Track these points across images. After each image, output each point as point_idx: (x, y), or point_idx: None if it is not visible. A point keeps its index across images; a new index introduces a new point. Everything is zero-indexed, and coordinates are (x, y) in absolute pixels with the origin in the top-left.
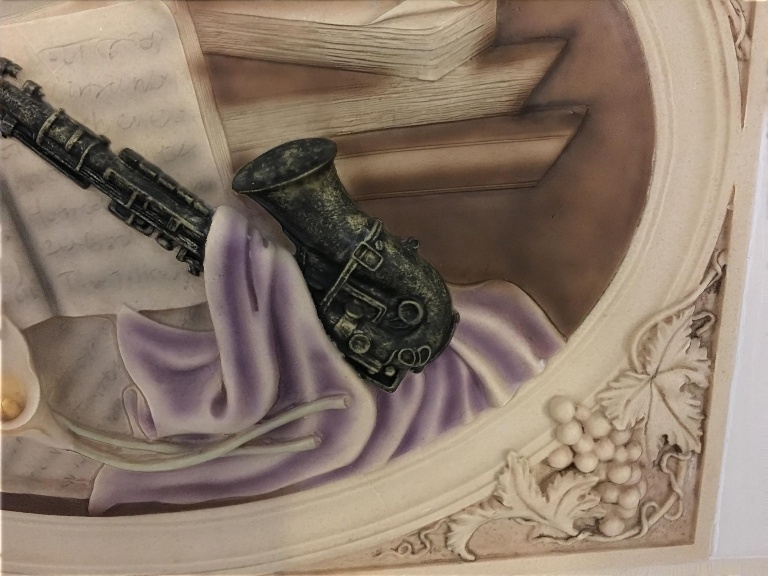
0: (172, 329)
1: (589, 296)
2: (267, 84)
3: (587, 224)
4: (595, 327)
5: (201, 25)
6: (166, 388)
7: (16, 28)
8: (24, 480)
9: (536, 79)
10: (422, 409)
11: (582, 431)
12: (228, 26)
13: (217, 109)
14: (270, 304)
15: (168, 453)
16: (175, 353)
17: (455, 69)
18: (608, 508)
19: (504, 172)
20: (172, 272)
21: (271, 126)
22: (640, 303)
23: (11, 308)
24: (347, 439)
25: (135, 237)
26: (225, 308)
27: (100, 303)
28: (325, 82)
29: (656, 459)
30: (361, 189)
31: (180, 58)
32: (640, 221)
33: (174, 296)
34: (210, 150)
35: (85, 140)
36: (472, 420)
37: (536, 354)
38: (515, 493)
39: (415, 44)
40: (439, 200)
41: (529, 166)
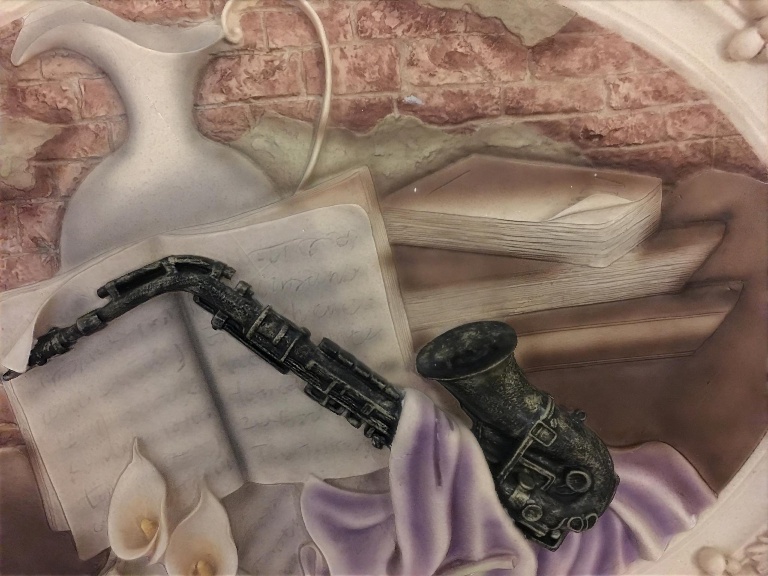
0: (351, 493)
1: (739, 454)
2: (447, 272)
3: (739, 388)
4: (744, 482)
5: (389, 220)
6: (343, 547)
7: (231, 234)
8: None
9: (698, 262)
10: (577, 561)
11: None
12: (414, 221)
13: (401, 295)
14: (453, 480)
15: None
16: (352, 514)
17: (623, 256)
18: None
19: (663, 344)
20: (355, 443)
21: (449, 308)
22: None
23: (211, 480)
24: None
25: (324, 413)
26: (406, 479)
27: (290, 473)
28: (502, 270)
29: None
30: (529, 363)
31: (372, 253)
32: None
33: (356, 465)
34: (394, 333)
35: (290, 334)
36: (624, 571)
37: (688, 510)
38: None
39: (588, 237)
40: (601, 370)
41: (687, 339)
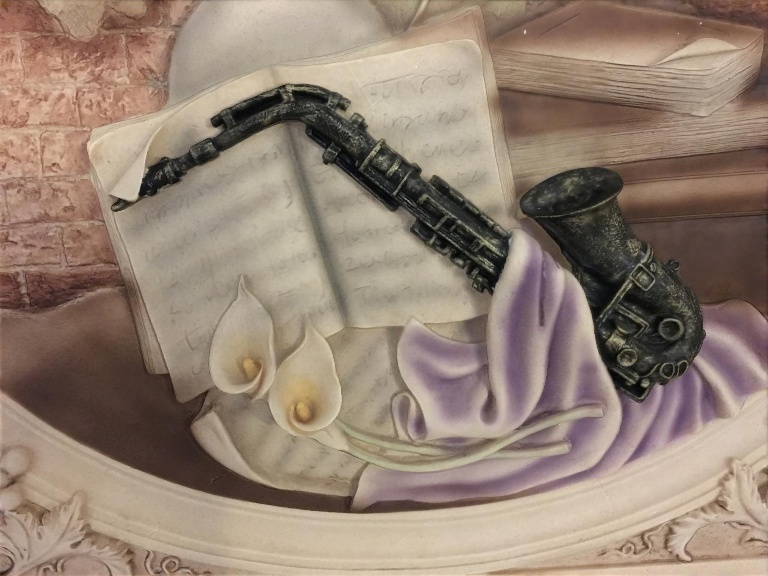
0: (447, 341)
1: None
2: (552, 117)
3: None
4: None
5: (497, 63)
6: (436, 395)
7: (347, 65)
8: (294, 478)
9: None
10: (657, 418)
11: None
12: (522, 64)
13: (506, 140)
14: (555, 320)
15: (432, 455)
16: (446, 363)
17: (724, 106)
18: None
19: (754, 200)
20: (455, 288)
21: (551, 156)
22: None
23: (315, 319)
24: (591, 445)
25: (427, 256)
26: (506, 322)
27: (391, 316)
28: (606, 116)
29: None
30: (625, 214)
31: (481, 93)
32: None
33: (455, 310)
34: (499, 177)
35: (403, 168)
36: (701, 429)
37: (765, 369)
38: (738, 499)
39: (693, 83)
40: (692, 225)
41: None
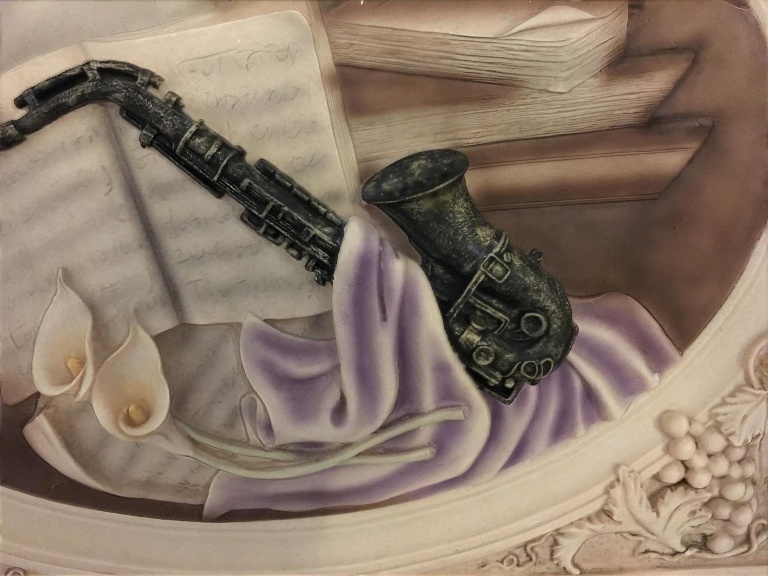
0: (294, 338)
1: (706, 310)
2: (397, 95)
3: (707, 237)
4: (710, 341)
5: (334, 37)
6: (285, 396)
7: (159, 40)
8: (141, 485)
9: (665, 91)
10: (534, 421)
11: (696, 446)
12: (361, 38)
13: (346, 120)
14: (399, 315)
15: (284, 461)
16: (295, 362)
17: (585, 81)
18: (718, 525)
19: (627, 184)
20: (297, 281)
21: (398, 137)
22: (757, 317)
23: (142, 315)
24: (460, 450)
25: (263, 246)
26: (350, 318)
27: (227, 311)
28: (455, 93)
29: (767, 476)
30: (484, 200)
31: (314, 69)
32: (761, 234)
33: (298, 305)
34: (339, 161)
35: (223, 151)
36: (583, 433)
37: (651, 368)
38: (625, 508)
39: (547, 56)
40: (561, 212)
41: (653, 178)
